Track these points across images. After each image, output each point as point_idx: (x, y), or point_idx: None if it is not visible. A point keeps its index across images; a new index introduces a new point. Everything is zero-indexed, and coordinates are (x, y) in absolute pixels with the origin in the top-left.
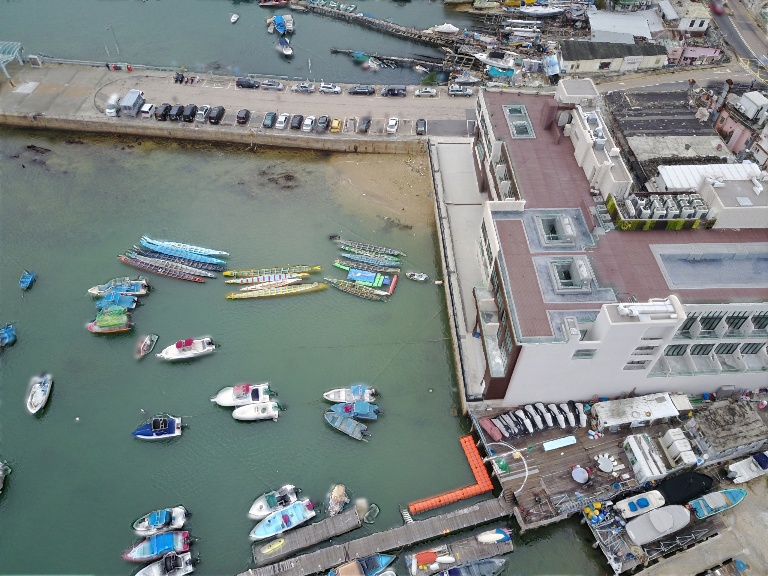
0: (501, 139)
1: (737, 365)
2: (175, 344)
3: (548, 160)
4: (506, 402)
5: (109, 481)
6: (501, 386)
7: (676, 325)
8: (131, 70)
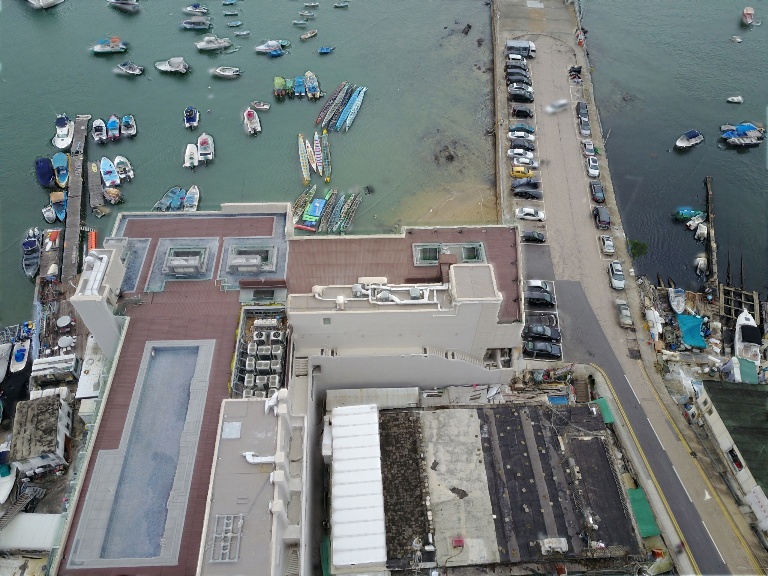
0: (412, 236)
1: None
2: None
3: (372, 272)
4: None
5: (165, 106)
6: None
7: None
8: (580, 44)
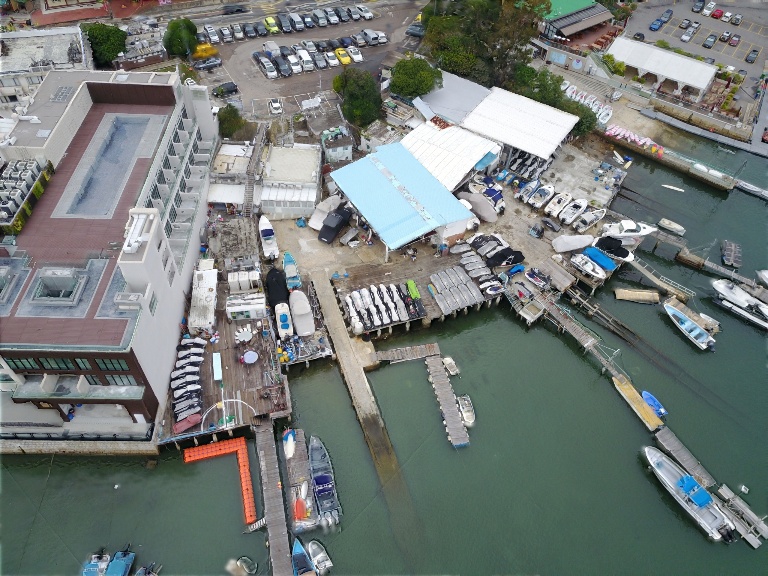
0: None
1: (188, 215)
2: None
3: None
4: (161, 404)
5: None
6: (150, 397)
7: (159, 220)
8: None
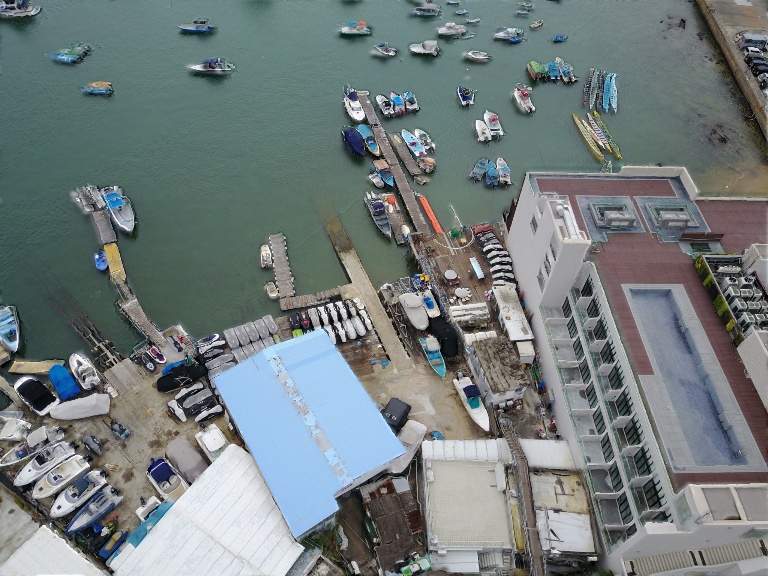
0: None
1: None
2: (524, 91)
3: None
4: (508, 240)
5: (432, 85)
6: None
7: None
8: None
